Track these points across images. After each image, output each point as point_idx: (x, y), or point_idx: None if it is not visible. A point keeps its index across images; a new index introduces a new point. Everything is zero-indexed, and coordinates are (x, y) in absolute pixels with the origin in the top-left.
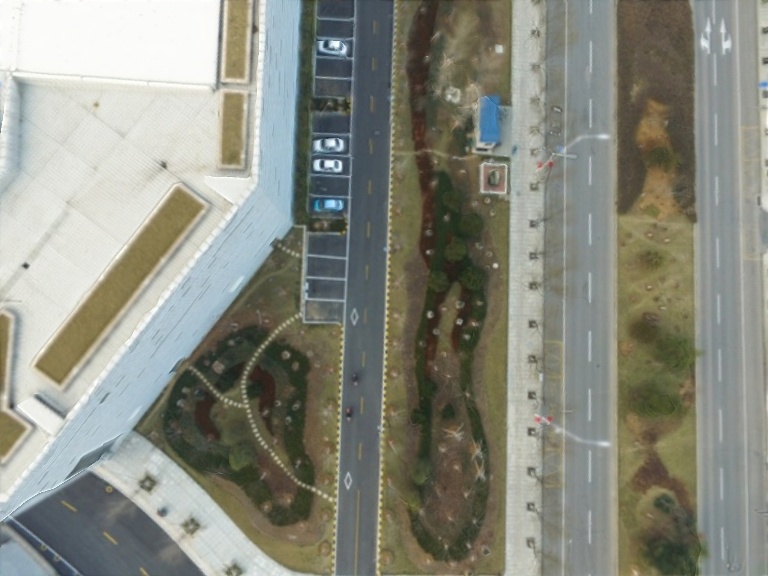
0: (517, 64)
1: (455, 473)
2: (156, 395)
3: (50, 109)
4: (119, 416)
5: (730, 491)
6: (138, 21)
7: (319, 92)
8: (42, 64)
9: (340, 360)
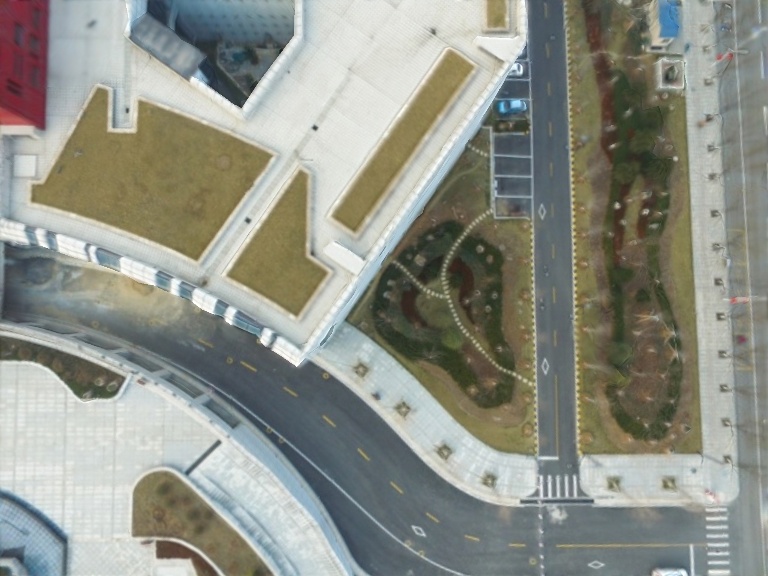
0: None
1: (649, 356)
2: (364, 288)
3: None
4: (358, 291)
5: None
6: None
7: None
8: None
9: (531, 253)
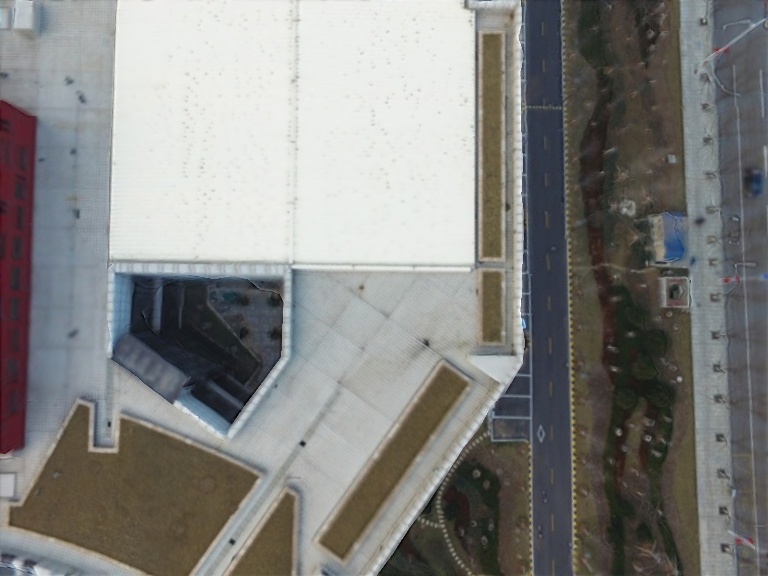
0: (690, 173)
1: None
2: None
3: (319, 294)
4: None
5: None
6: (400, 208)
7: None
8: (315, 254)
9: (529, 477)
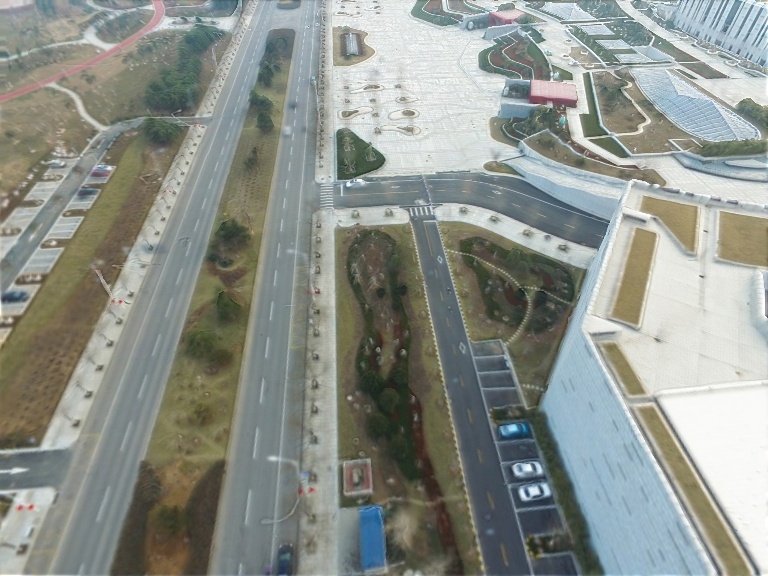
0: None
1: None
2: None
3: None
4: None
5: (174, 273)
6: (759, 441)
7: (568, 560)
8: None
9: (465, 320)
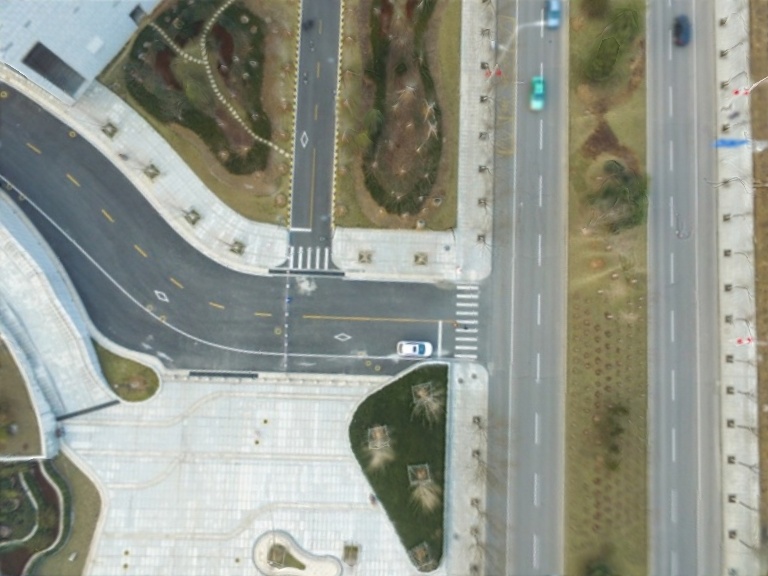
0: None
1: (408, 132)
2: (118, 48)
3: None
4: (76, 15)
5: (680, 163)
6: None
7: None
8: None
9: (298, 27)
